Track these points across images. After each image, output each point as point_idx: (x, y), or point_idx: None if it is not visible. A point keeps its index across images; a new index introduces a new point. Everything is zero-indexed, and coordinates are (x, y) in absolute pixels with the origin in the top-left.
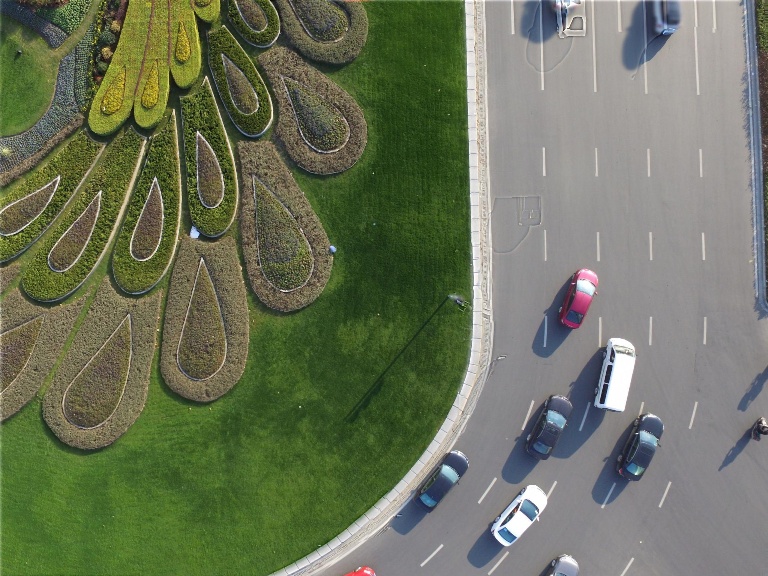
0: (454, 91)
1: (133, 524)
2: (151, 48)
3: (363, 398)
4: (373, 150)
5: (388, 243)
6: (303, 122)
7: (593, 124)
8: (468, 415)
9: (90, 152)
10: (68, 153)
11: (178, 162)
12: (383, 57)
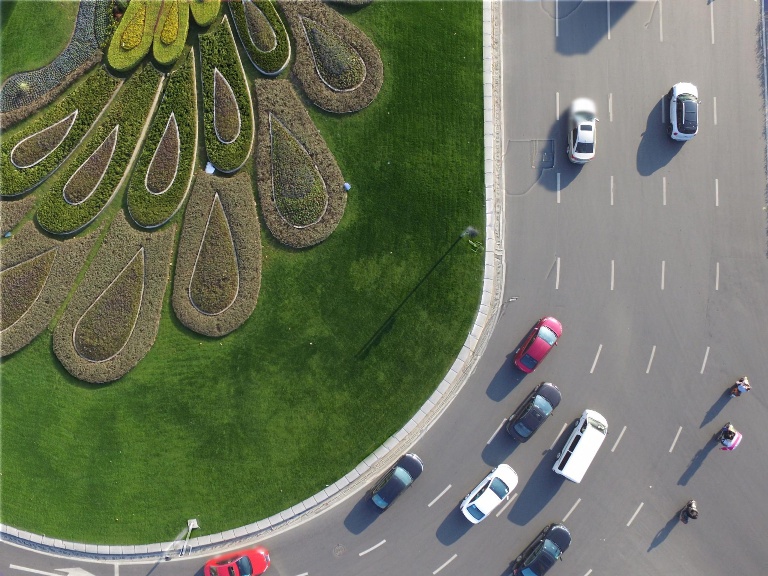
0: (470, 35)
1: (140, 460)
2: None
3: (374, 336)
4: (389, 90)
5: (402, 182)
6: (320, 61)
7: (606, 70)
8: (478, 356)
9: (108, 87)
10: (86, 87)
11: (195, 98)
12: None
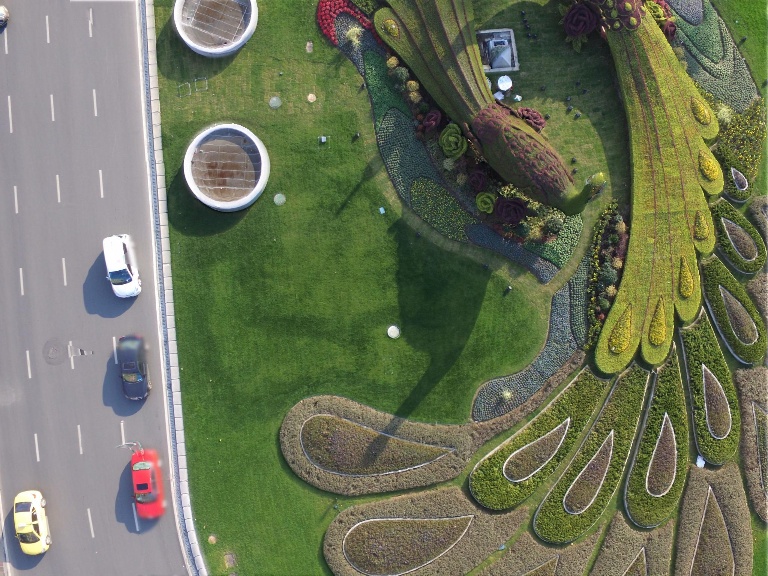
0: None
1: None
2: (655, 284)
3: None
4: None
5: None
6: None
7: None
8: None
9: (598, 391)
10: (577, 394)
11: (683, 395)
12: None
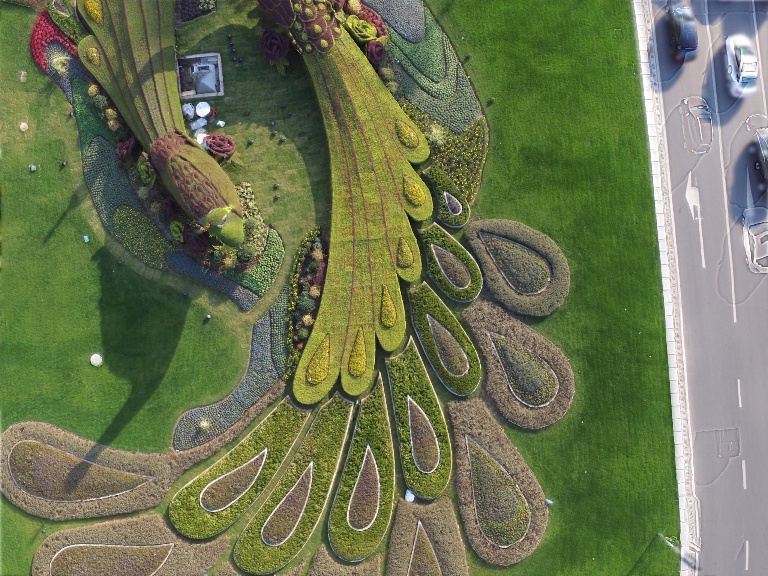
0: (654, 332)
1: None
2: (354, 313)
3: None
4: (581, 399)
5: (600, 489)
6: (513, 379)
7: None
8: None
9: (297, 422)
10: (274, 425)
11: (389, 427)
12: (585, 304)
